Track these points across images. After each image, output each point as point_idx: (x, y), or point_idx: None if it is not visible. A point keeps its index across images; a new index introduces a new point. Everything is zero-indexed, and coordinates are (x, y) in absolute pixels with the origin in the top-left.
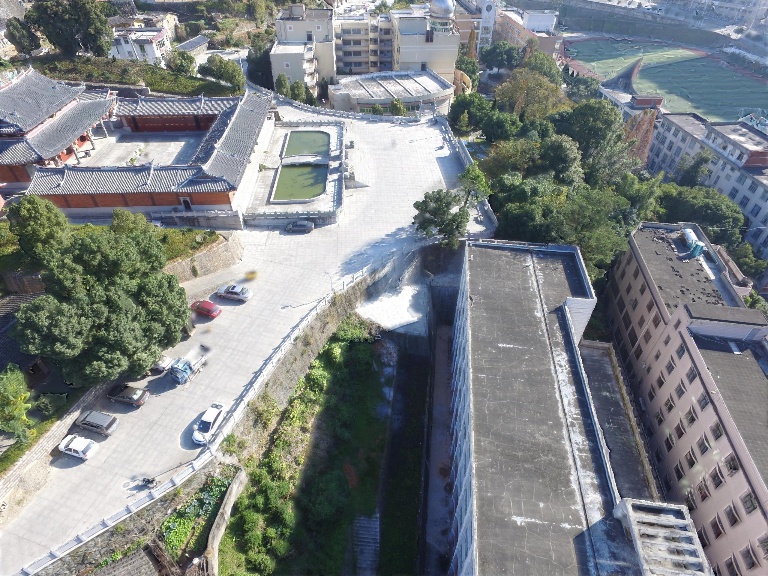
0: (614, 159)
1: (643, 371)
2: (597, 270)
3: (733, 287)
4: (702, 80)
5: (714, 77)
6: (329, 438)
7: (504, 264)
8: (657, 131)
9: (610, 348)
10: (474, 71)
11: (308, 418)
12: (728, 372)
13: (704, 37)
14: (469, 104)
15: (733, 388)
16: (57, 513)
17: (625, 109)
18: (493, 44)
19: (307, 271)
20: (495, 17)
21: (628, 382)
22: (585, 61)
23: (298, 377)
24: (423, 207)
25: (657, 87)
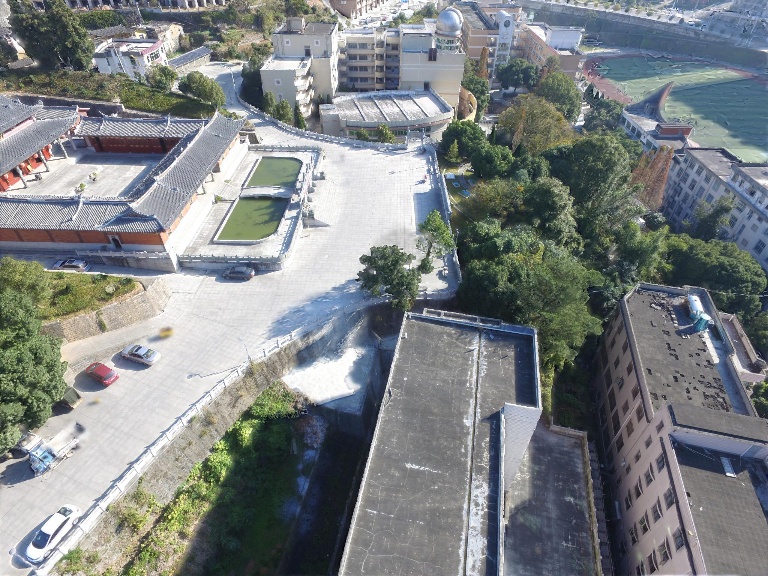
0: (616, 204)
1: (622, 469)
2: (568, 350)
3: (739, 377)
4: (744, 105)
5: (758, 102)
6: (211, 547)
7: (443, 346)
8: (679, 167)
9: (584, 438)
10: (483, 91)
11: (191, 519)
12: (714, 502)
13: (751, 57)
14: (461, 133)
15: (718, 527)
16: None
17: (648, 138)
18: (510, 62)
19: (231, 330)
20: (513, 33)
21: (601, 484)
22: (616, 80)
23: (193, 463)
24: (369, 263)
25: (692, 111)
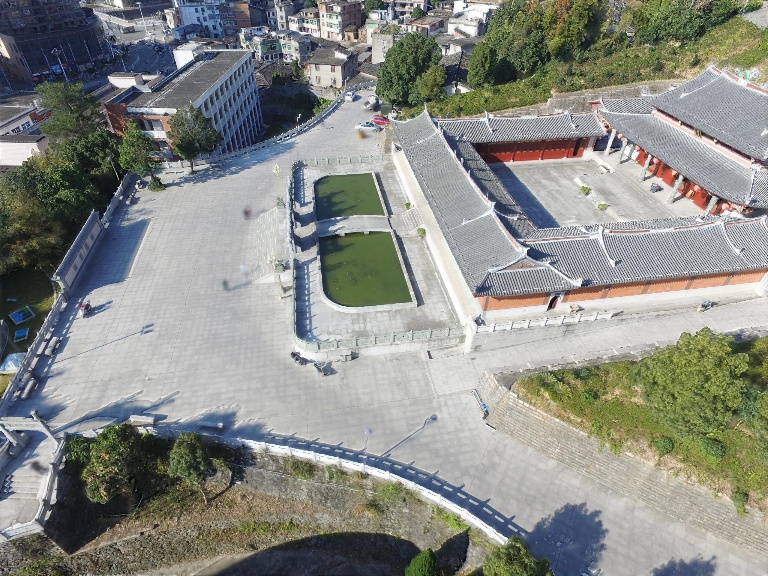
0: None
1: None
2: None
3: None
4: None
5: None
6: None
7: None
8: None
9: None
10: None
11: None
12: None
13: None
14: None
15: None
16: None
17: None
18: None
19: (321, 143)
20: None
21: None
22: None
23: None
24: None
25: None
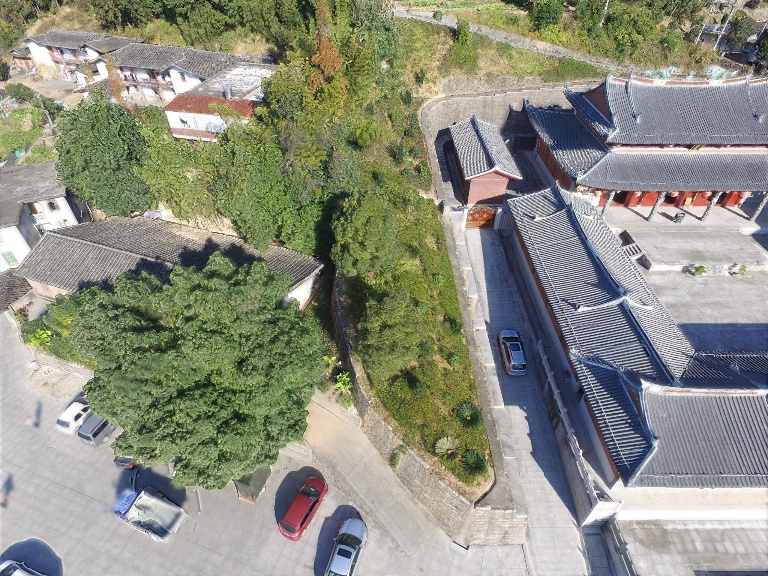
0: None
1: None
2: None
3: None
4: None
5: None
6: None
7: None
8: None
9: None
10: None
11: None
12: None
13: None
14: None
15: None
16: (6, 423)
17: None
18: None
19: None
20: None
21: None
22: None
23: None
24: None
25: None
